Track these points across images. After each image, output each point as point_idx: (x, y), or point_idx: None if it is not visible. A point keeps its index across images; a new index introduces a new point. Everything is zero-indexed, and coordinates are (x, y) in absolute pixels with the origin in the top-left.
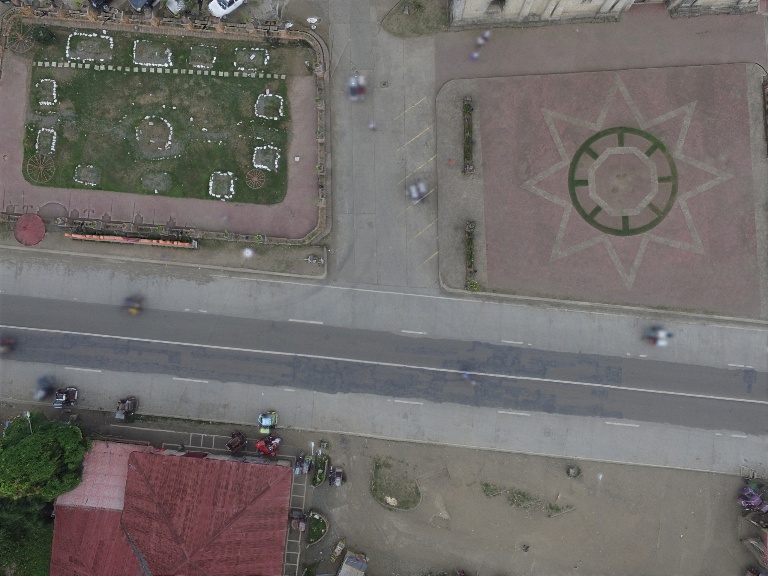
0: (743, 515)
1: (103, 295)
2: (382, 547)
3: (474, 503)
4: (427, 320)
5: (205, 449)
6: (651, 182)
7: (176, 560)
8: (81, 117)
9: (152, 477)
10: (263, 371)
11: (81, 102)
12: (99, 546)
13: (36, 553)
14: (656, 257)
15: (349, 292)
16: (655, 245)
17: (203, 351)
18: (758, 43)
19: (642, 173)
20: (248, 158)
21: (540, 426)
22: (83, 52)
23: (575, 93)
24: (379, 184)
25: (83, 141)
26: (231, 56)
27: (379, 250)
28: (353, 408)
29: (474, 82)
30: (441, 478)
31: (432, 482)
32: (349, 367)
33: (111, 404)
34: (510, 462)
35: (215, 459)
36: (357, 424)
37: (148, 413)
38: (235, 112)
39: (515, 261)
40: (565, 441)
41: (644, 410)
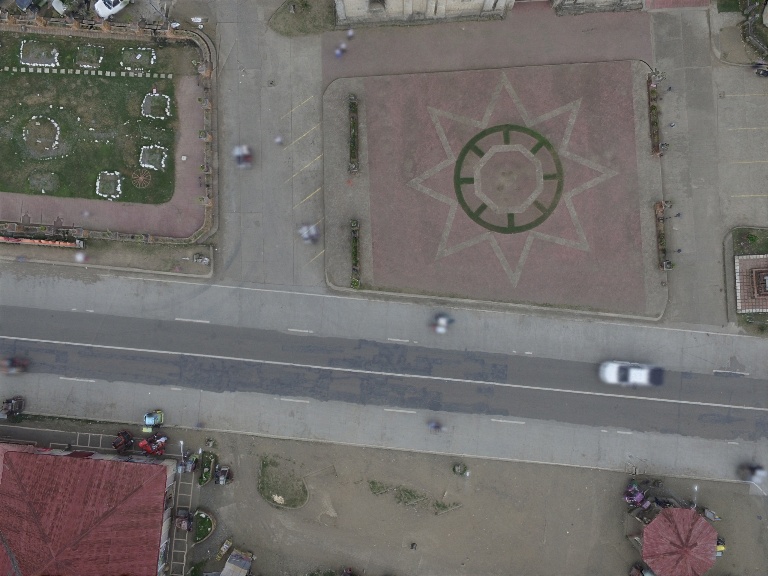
0: (629, 511)
1: None
2: (270, 545)
3: (361, 501)
4: (313, 318)
5: (92, 448)
6: (536, 179)
7: (43, 559)
8: None
9: (25, 476)
10: (150, 370)
11: None
12: None
13: None
14: (541, 254)
15: (236, 291)
16: (540, 242)
17: (90, 350)
18: (644, 40)
19: (527, 171)
20: (135, 158)
21: (426, 424)
22: None
23: (461, 91)
24: (266, 183)
25: None
26: (118, 56)
27: (266, 249)
28: (240, 407)
29: (360, 81)
30: (328, 476)
31: (319, 480)
32: (235, 366)
33: None
34: (397, 460)
35: (90, 458)
36: (244, 423)
37: (35, 413)
38: (122, 112)
39: (401, 259)
40: (451, 438)
41: (530, 407)
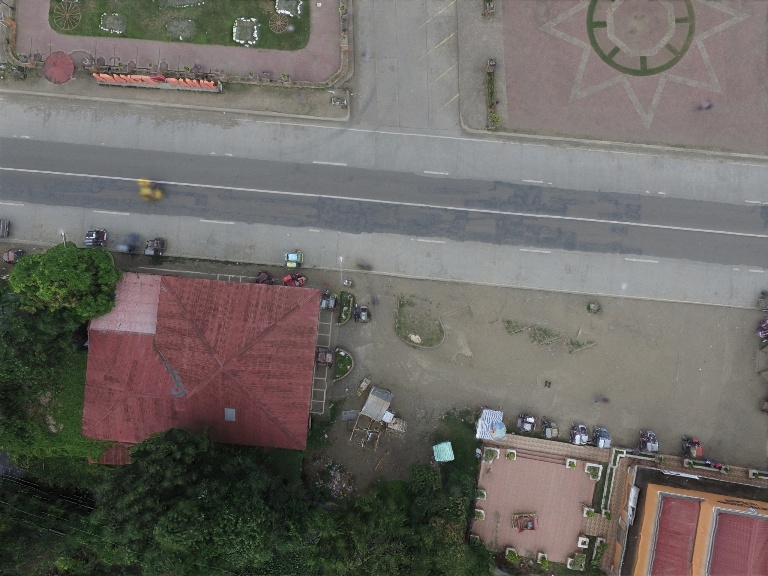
0: (760, 348)
1: (130, 140)
2: (406, 384)
3: (496, 340)
4: (449, 161)
5: None
6: (668, 23)
7: (209, 370)
8: None
9: (184, 297)
10: (288, 212)
11: None
12: (133, 365)
13: (70, 380)
14: (674, 96)
15: (372, 134)
16: (673, 84)
17: (229, 193)
18: None
19: (659, 14)
20: (271, 4)
21: (561, 263)
22: None
23: None
24: (400, 29)
25: None
26: None
27: (401, 93)
28: (377, 247)
29: None
30: (464, 316)
31: (455, 320)
32: (373, 207)
33: (139, 246)
34: (531, 299)
35: None
36: (381, 263)
37: (176, 255)
38: None
39: (535, 102)
40: (585, 278)
41: (663, 246)
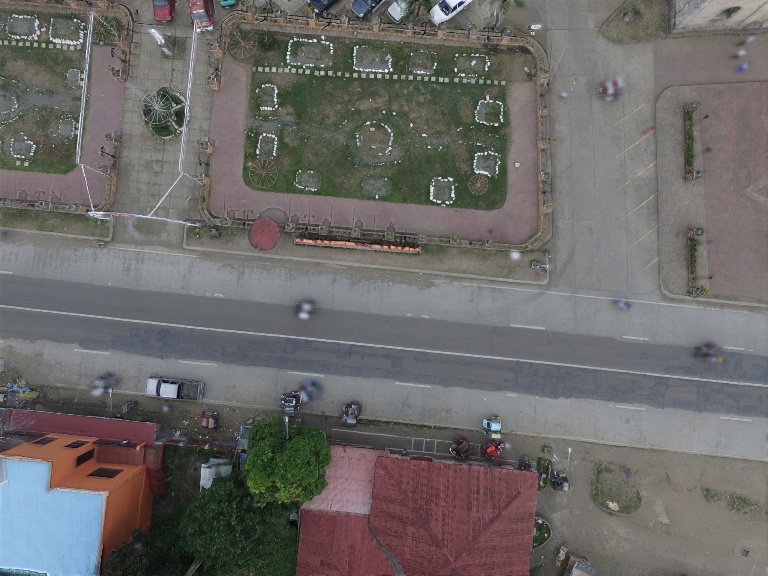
0: None
1: (325, 300)
2: (602, 551)
3: (694, 508)
4: (648, 326)
5: (427, 453)
6: None
7: (438, 565)
8: (301, 122)
9: (403, 482)
10: (485, 376)
11: (301, 107)
12: (351, 550)
13: (276, 557)
14: None
15: (570, 298)
16: None
17: (425, 356)
18: None
19: None
20: (468, 164)
21: (762, 432)
22: (304, 58)
23: None
24: (599, 190)
25: (303, 146)
26: (451, 62)
27: (599, 256)
28: (575, 413)
29: (694, 89)
30: (661, 483)
31: (652, 487)
32: (571, 372)
33: (334, 408)
34: (731, 467)
35: (462, 464)
36: (579, 429)
37: (371, 417)
38: (455, 118)
39: (737, 267)
40: None
41: None
